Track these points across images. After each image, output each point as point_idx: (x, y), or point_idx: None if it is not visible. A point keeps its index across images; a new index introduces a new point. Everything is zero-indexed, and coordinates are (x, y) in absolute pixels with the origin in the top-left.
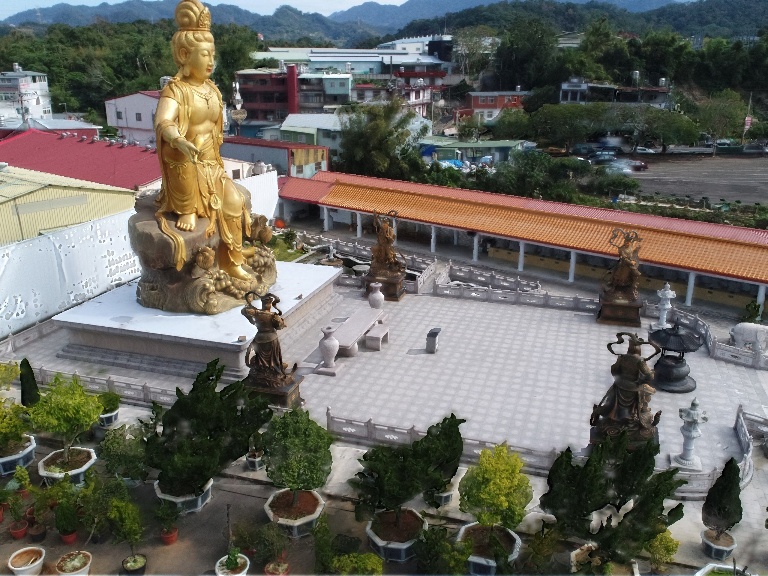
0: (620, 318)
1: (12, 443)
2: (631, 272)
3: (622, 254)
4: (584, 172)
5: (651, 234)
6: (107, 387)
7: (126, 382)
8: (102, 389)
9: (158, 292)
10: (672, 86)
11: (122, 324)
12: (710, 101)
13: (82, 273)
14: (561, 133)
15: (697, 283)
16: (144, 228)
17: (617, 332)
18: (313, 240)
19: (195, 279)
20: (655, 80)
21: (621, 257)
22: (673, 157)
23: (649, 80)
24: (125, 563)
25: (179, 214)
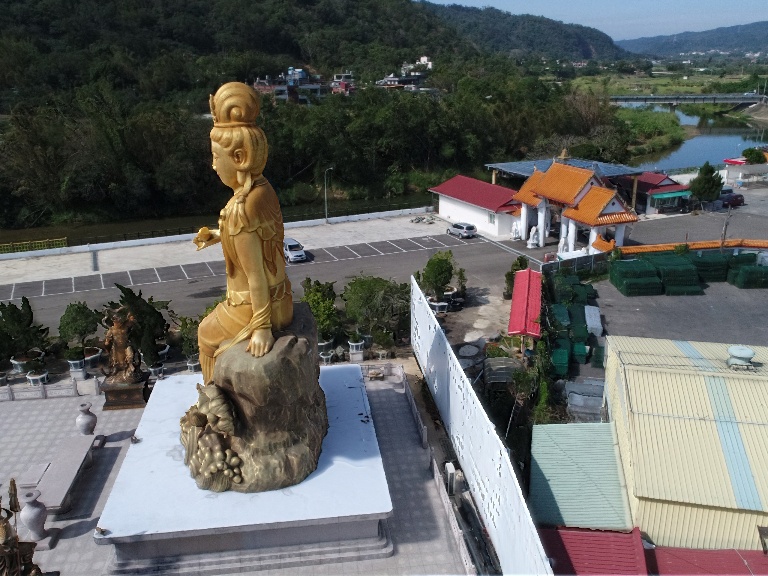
0: None
1: None
2: None
3: None
4: None
5: None
6: None
7: None
8: None
9: None
10: None
11: None
12: None
13: None
14: None
15: None
16: None
17: None
18: None
19: None
20: None
21: None
22: None
23: None
24: None
25: None
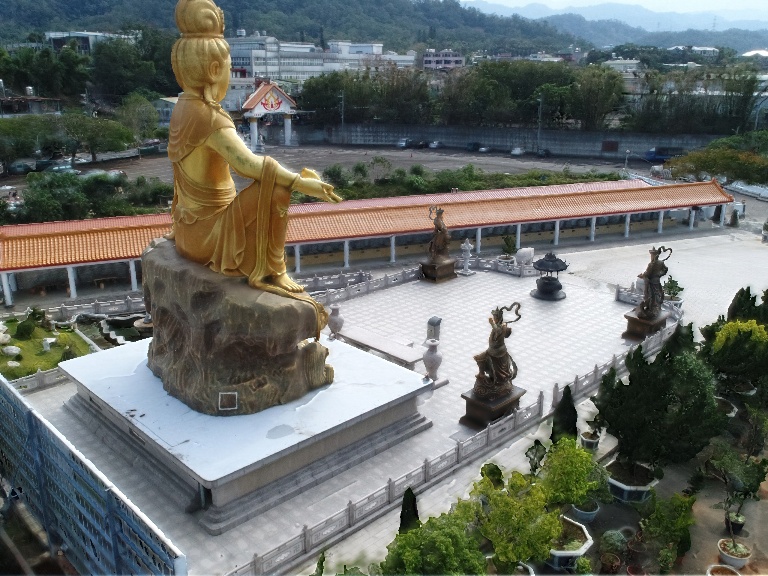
0: (446, 275)
1: (492, 575)
2: (445, 237)
3: (442, 225)
4: (126, 185)
5: (395, 211)
6: (386, 495)
7: (408, 473)
8: (380, 502)
9: (271, 385)
10: (86, 94)
11: (300, 433)
12: (123, 107)
13: (6, 446)
14: (4, 152)
15: (423, 241)
16: (277, 302)
17: (459, 284)
18: (48, 315)
19: (314, 347)
20: (20, 89)
21: (443, 227)
22: (109, 164)
23: (12, 89)
24: (738, 522)
25: (278, 276)
